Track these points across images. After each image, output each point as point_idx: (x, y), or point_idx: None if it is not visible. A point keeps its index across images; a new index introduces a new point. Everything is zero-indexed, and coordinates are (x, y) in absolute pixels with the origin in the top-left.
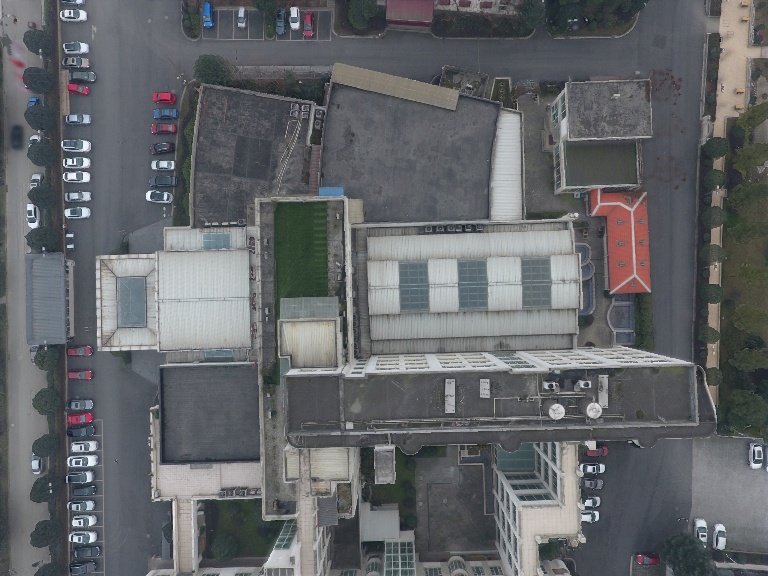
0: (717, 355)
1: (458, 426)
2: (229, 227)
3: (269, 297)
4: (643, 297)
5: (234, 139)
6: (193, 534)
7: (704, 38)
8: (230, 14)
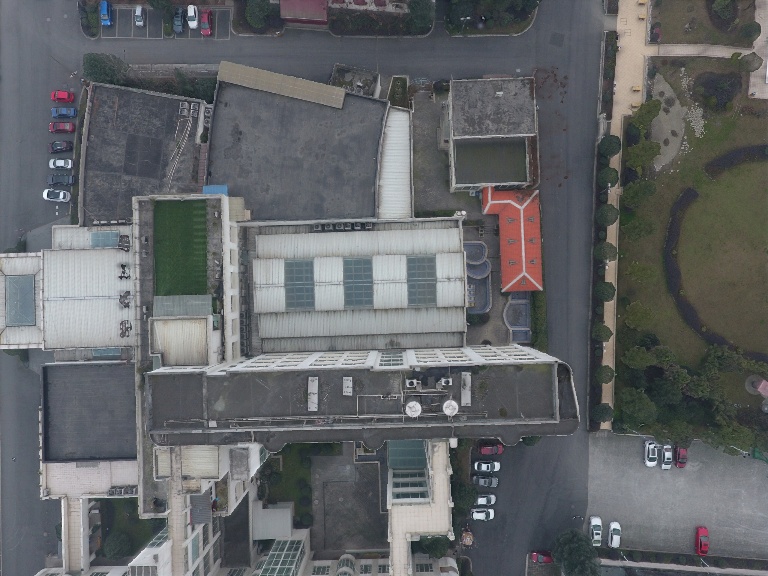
0: (613, 353)
1: (321, 424)
2: (118, 225)
3: (148, 295)
4: (537, 295)
5: (125, 137)
6: (82, 532)
7: (602, 36)
8: (129, 13)
